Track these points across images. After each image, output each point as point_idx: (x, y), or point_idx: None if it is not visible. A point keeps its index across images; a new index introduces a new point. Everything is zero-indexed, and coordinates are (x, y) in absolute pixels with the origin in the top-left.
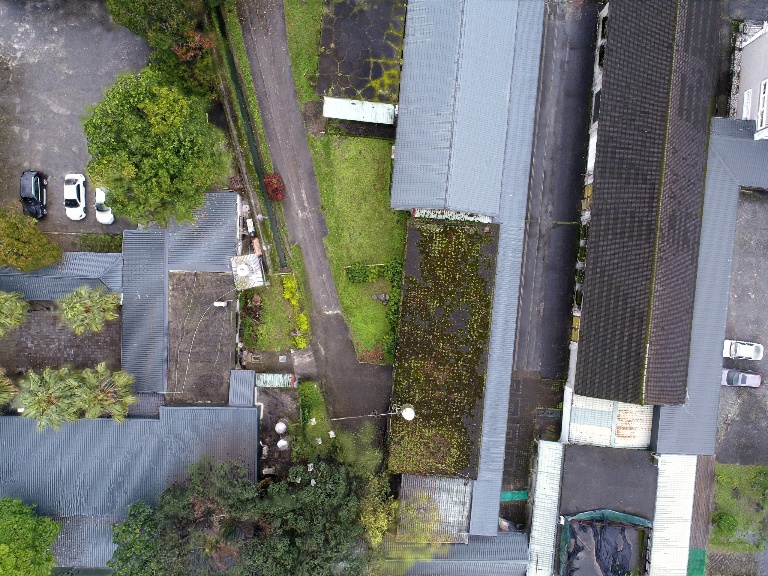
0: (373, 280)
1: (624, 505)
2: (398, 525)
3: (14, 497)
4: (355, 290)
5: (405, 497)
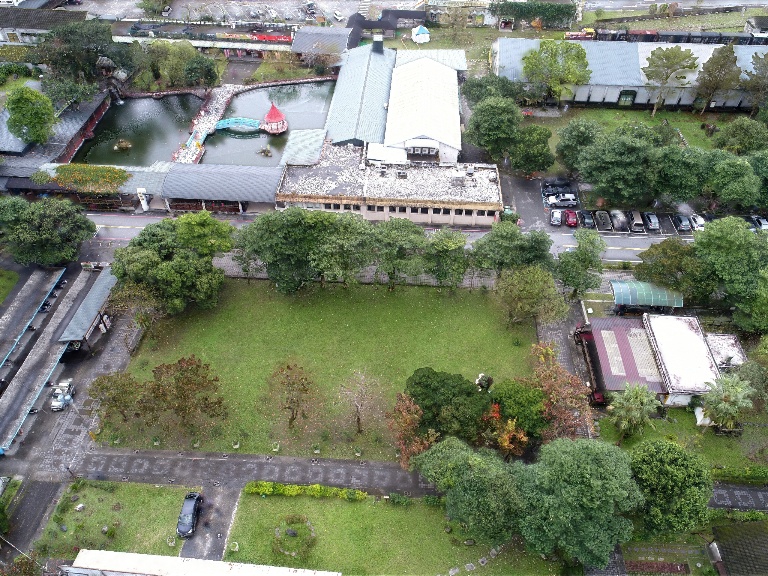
0: (5, 76)
1: (131, 25)
2: (112, 66)
3: (18, 143)
4: (8, 86)
5: (100, 64)
